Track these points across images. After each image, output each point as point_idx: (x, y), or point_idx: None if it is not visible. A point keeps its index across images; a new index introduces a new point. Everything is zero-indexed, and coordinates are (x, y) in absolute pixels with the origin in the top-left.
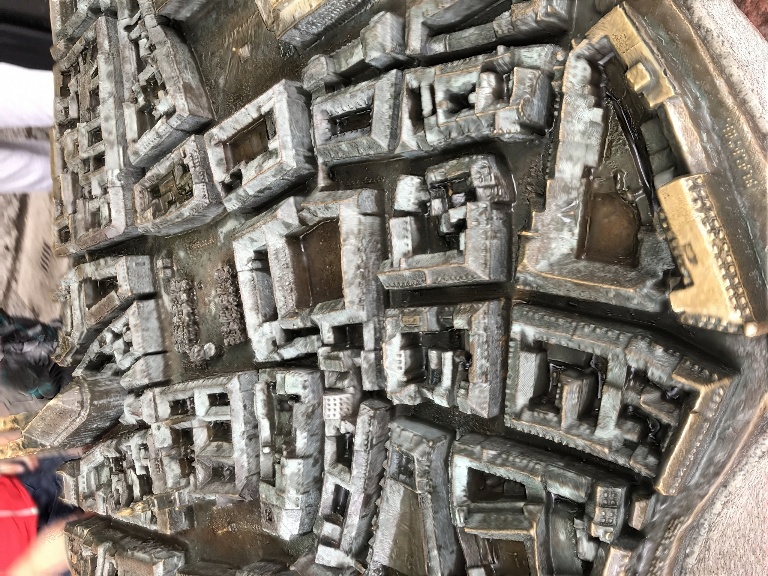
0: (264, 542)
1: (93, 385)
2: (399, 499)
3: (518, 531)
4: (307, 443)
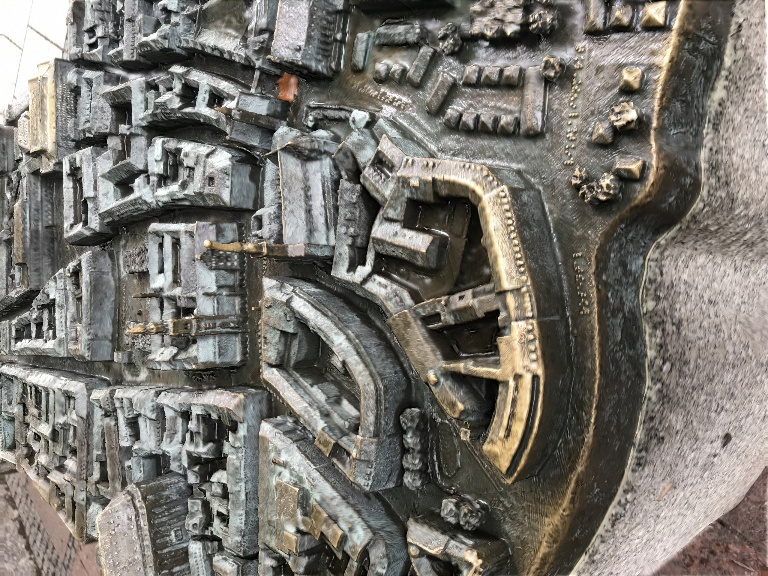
0: None
1: None
2: None
3: None
4: None
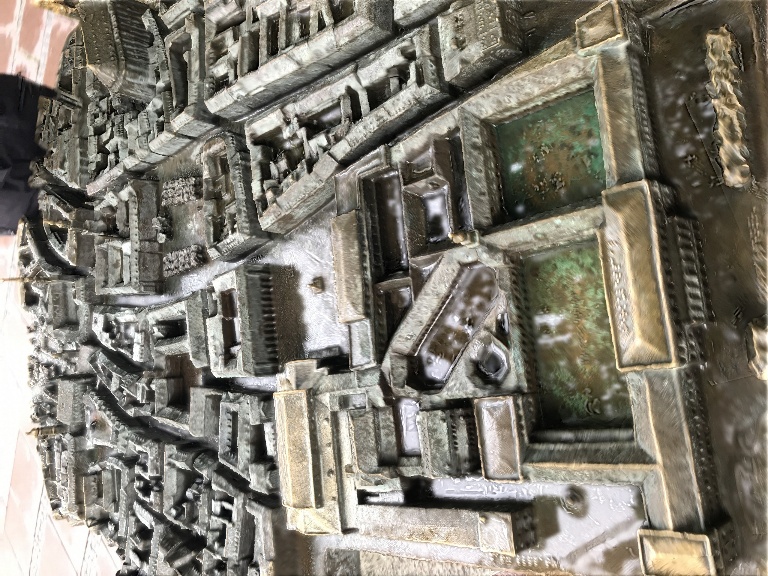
0: None
1: (126, 87)
2: (111, 426)
3: (104, 502)
4: None
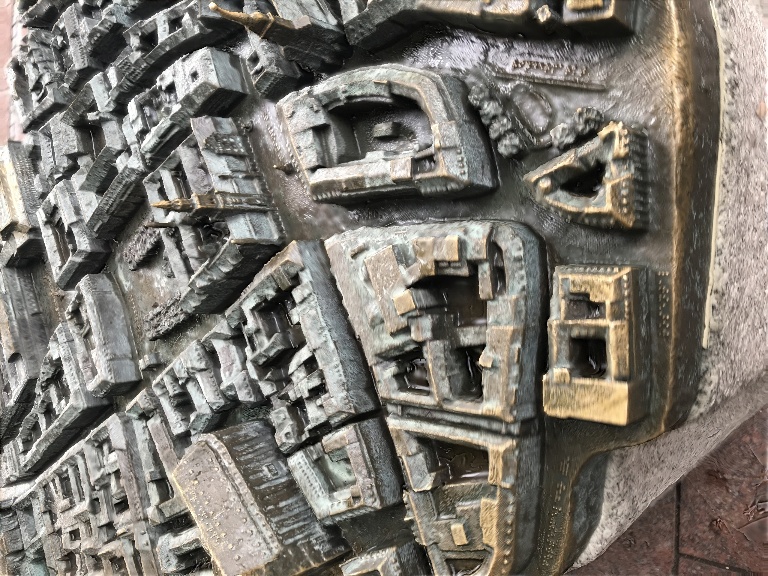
0: (275, 112)
1: None
2: None
3: None
4: None
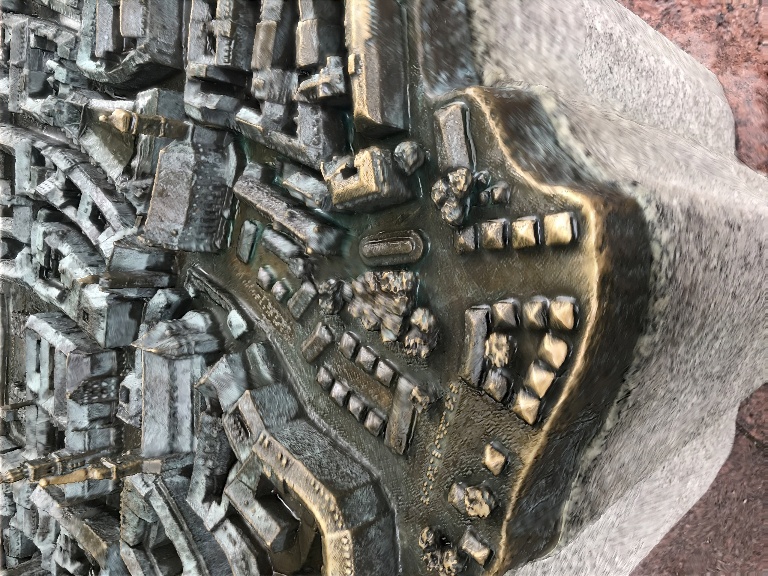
0: None
1: None
2: (93, 136)
3: None
4: (72, 247)
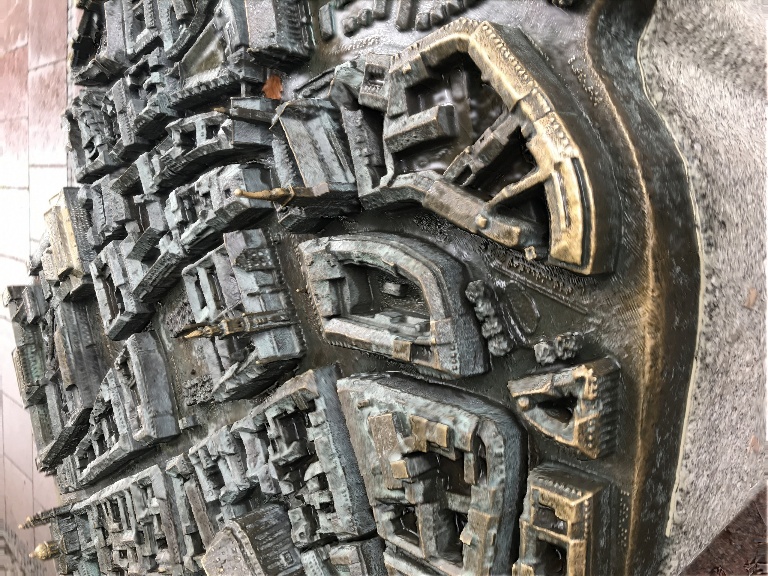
0: None
1: None
2: None
3: None
4: None
